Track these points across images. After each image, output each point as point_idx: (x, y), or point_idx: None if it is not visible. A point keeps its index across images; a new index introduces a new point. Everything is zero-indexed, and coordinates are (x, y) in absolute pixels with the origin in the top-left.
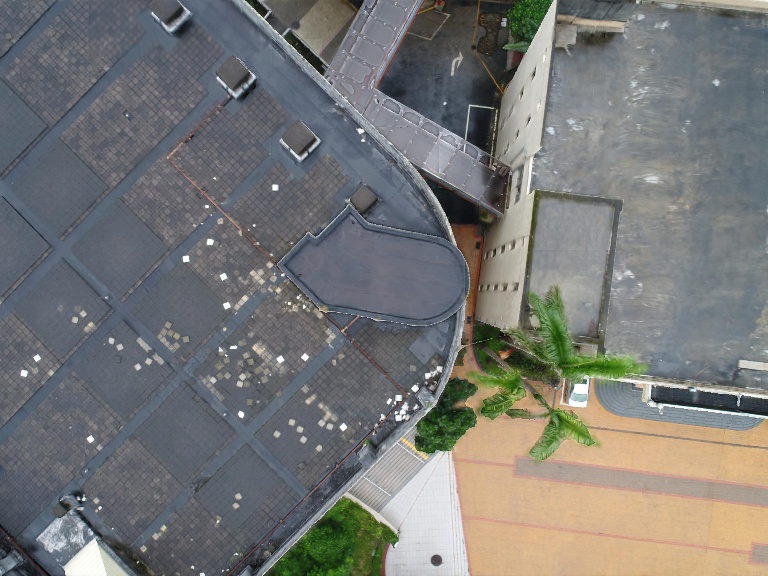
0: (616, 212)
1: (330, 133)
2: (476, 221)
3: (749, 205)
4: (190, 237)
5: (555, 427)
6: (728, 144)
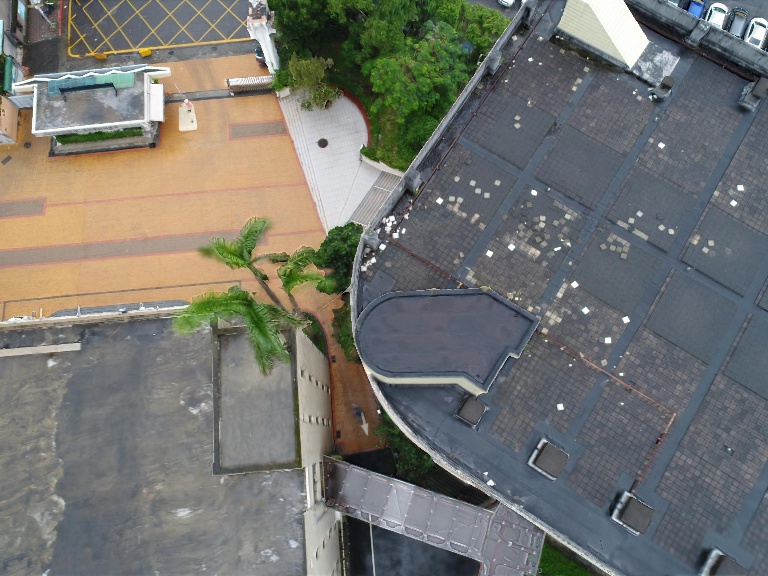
0: (218, 462)
1: (521, 475)
2: (345, 459)
3: (83, 505)
4: (629, 342)
5: (247, 248)
6: (110, 567)
